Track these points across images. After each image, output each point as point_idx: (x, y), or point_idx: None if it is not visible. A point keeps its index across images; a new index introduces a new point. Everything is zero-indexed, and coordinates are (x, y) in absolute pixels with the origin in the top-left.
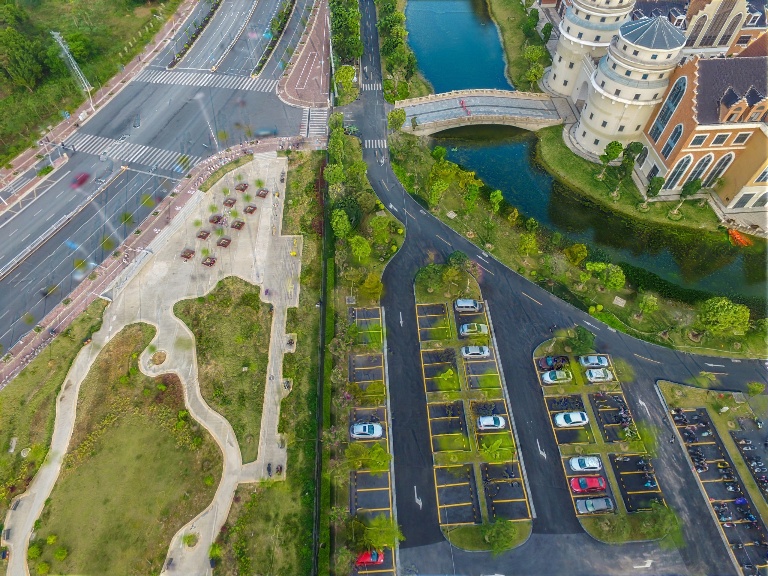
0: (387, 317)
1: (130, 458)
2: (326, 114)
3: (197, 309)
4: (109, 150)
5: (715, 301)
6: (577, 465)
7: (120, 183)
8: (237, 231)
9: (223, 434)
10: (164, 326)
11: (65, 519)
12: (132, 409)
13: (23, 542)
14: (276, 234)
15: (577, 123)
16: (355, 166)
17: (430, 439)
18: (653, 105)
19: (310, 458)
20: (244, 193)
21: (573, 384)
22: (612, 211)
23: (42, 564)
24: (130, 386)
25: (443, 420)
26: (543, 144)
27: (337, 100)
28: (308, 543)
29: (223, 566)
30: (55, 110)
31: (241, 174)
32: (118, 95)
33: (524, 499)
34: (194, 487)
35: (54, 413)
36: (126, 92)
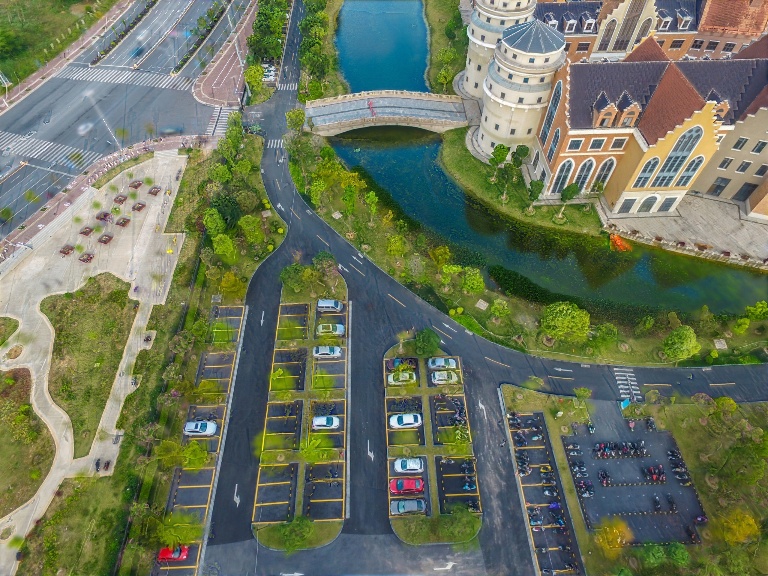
0: (249, 316)
1: None
2: None
3: (64, 305)
4: (13, 146)
5: (556, 306)
6: (399, 466)
7: (16, 178)
8: (121, 228)
9: (61, 429)
10: (27, 321)
11: None
12: None
13: None
14: (159, 232)
15: None
16: (239, 165)
17: (262, 438)
18: (540, 109)
19: (140, 454)
20: (137, 190)
21: (416, 386)
22: (499, 214)
23: None
24: None
25: (279, 419)
26: (445, 146)
27: (250, 99)
28: (118, 538)
29: (30, 559)
30: None
31: (138, 171)
32: (35, 91)
33: (341, 499)
34: (20, 481)
35: None
36: (43, 88)
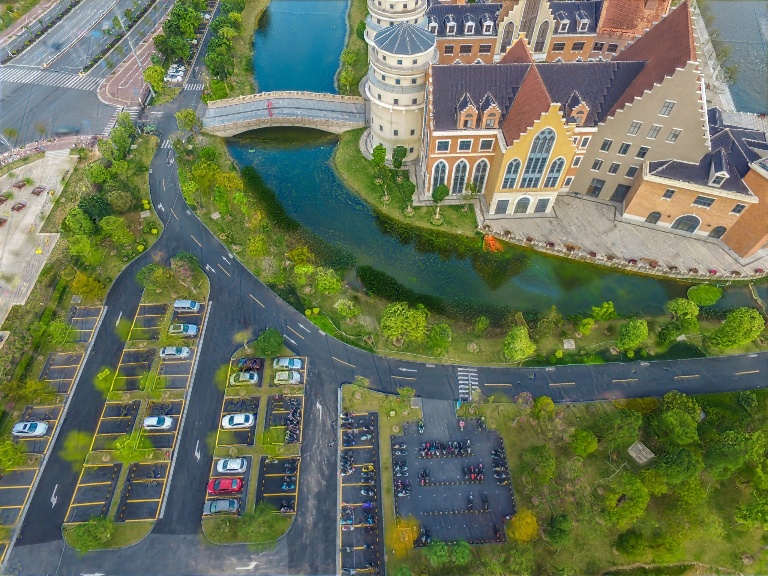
0: (106, 316)
1: None
2: (137, 113)
3: None
4: None
5: (392, 306)
6: (220, 466)
7: None
8: None
9: None
10: None
11: None
12: None
13: None
14: (34, 232)
15: None
16: (115, 165)
17: (93, 438)
18: (417, 110)
19: None
20: (20, 190)
21: (257, 386)
22: (380, 215)
23: None
24: None
25: (112, 420)
26: (340, 147)
27: (153, 99)
28: None
29: None
30: None
31: (26, 171)
32: None
33: (157, 499)
34: None
35: None
36: None
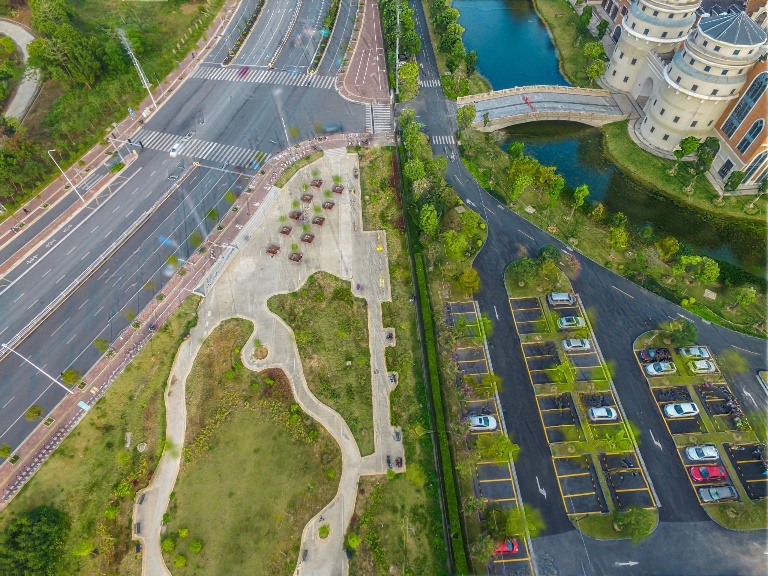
0: (482, 311)
1: (248, 452)
2: (389, 110)
3: (291, 304)
4: (177, 147)
5: None
6: (695, 454)
7: (194, 179)
8: (319, 227)
9: (337, 427)
10: (261, 321)
11: (193, 512)
12: (242, 403)
13: (154, 536)
14: (358, 229)
15: (641, 119)
16: (436, 161)
17: (544, 430)
18: (729, 100)
19: (428, 450)
20: (320, 189)
21: (677, 375)
22: (687, 206)
23: (179, 557)
24: (237, 381)
25: (555, 412)
26: (609, 140)
27: (398, 96)
28: (439, 533)
29: (358, 557)
30: (117, 107)
31: (313, 170)
32: (177, 92)
33: (647, 488)
34: (317, 480)
35: (164, 408)
36: (185, 89)
